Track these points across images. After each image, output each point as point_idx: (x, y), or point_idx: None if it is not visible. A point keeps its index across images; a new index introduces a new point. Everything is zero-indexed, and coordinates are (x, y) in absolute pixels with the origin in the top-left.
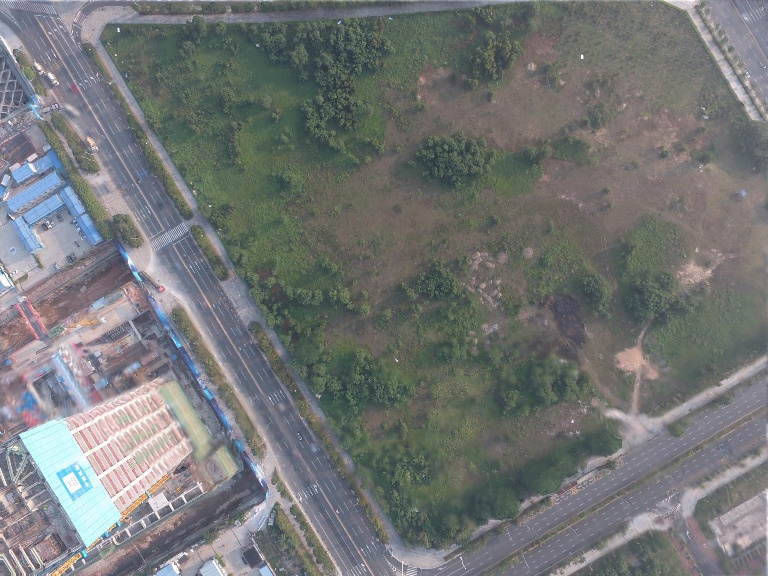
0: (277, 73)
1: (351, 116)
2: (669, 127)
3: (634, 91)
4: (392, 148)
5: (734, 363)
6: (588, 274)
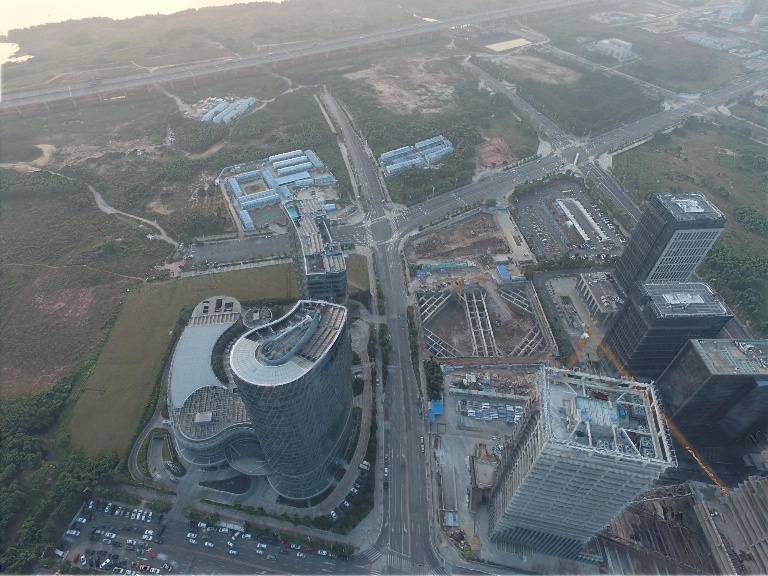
0: (766, 299)
1: (766, 260)
2: (671, 159)
3: (663, 168)
4: (766, 245)
5: (760, 144)
6: (765, 178)
